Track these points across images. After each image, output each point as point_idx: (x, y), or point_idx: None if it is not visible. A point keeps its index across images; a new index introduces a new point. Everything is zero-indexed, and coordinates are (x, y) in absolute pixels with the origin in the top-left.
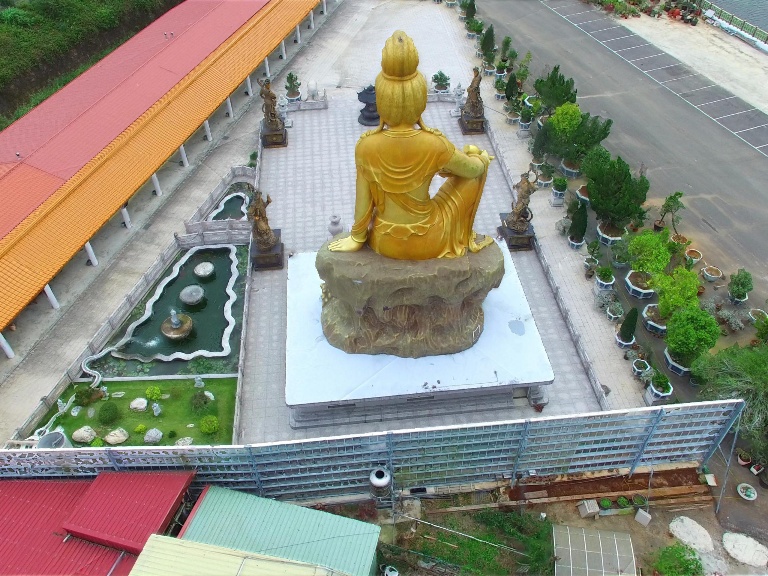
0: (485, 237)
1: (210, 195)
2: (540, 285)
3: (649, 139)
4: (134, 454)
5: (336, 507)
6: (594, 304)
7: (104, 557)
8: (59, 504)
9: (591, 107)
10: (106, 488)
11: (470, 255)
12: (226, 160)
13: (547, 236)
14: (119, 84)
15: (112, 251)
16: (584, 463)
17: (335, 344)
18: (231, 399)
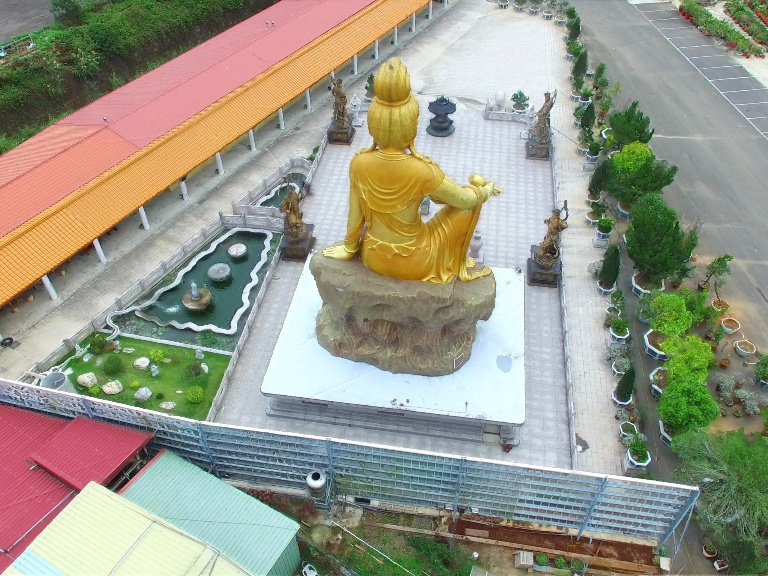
0: (484, 268)
1: (263, 181)
2: (552, 325)
3: (727, 192)
4: (105, 407)
5: (283, 497)
6: (601, 355)
7: (58, 491)
8: (38, 436)
9: (674, 149)
10: (77, 431)
11: (458, 283)
12: (291, 150)
13: (578, 276)
14: (211, 66)
15: (165, 219)
16: (529, 513)
17: (322, 344)
18: (223, 375)
